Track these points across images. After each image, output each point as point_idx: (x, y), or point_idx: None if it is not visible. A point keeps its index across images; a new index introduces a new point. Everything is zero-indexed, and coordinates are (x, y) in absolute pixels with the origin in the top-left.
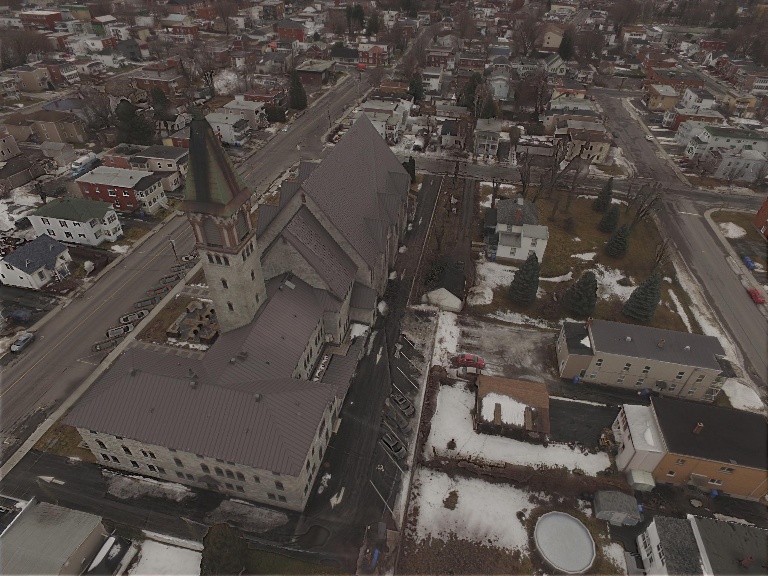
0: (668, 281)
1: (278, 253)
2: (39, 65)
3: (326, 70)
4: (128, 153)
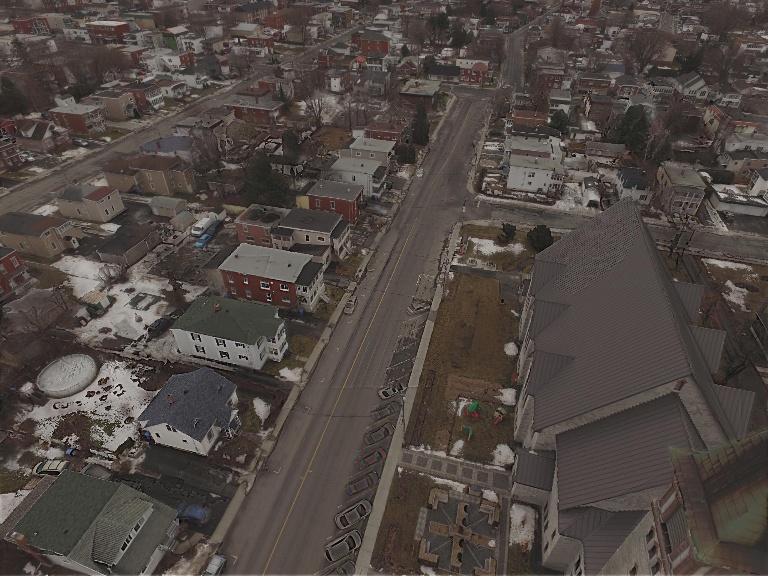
0: None
1: (661, 489)
2: (122, 89)
3: (436, 93)
4: (266, 220)
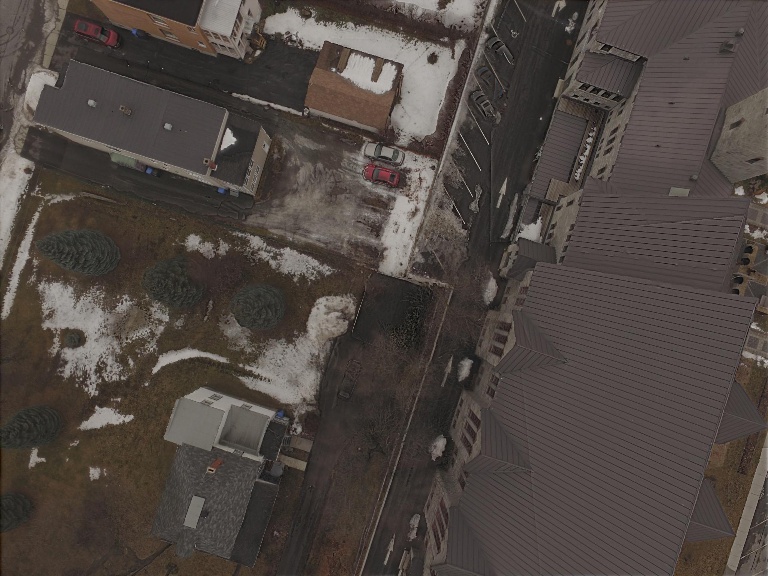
0: None
1: None
2: None
3: None
4: None
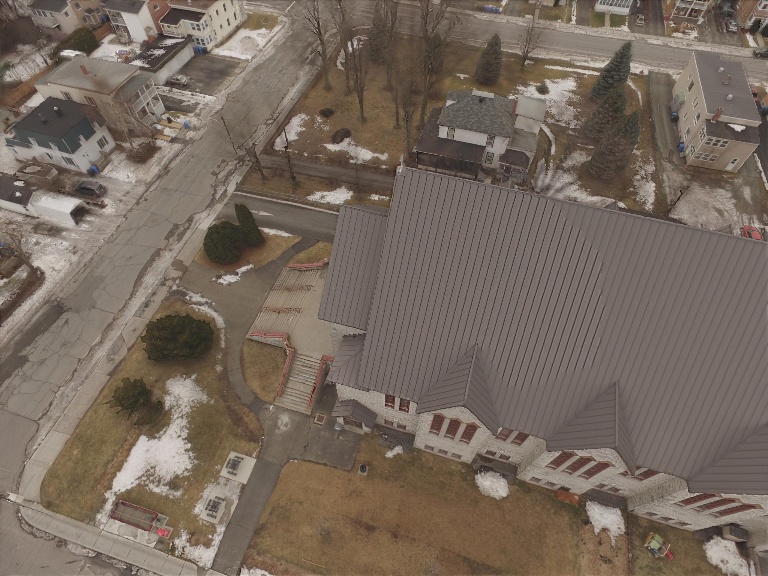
0: (529, 63)
1: None
2: None
3: None
4: None
